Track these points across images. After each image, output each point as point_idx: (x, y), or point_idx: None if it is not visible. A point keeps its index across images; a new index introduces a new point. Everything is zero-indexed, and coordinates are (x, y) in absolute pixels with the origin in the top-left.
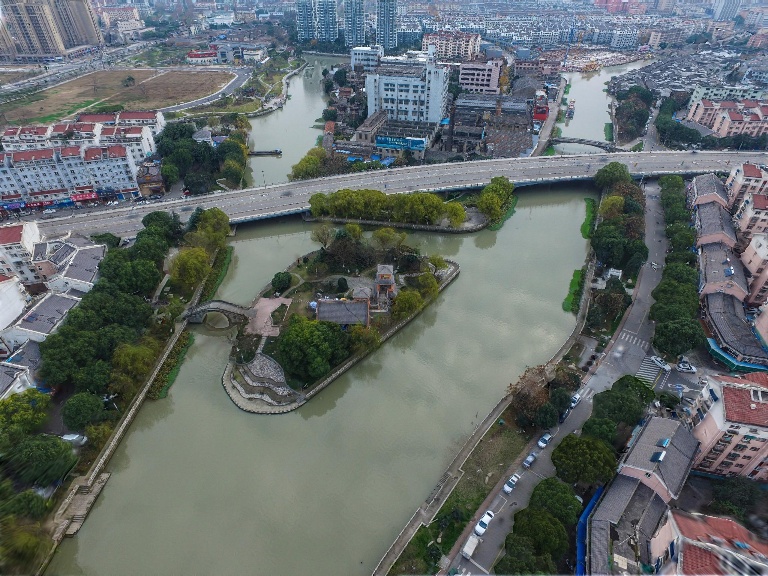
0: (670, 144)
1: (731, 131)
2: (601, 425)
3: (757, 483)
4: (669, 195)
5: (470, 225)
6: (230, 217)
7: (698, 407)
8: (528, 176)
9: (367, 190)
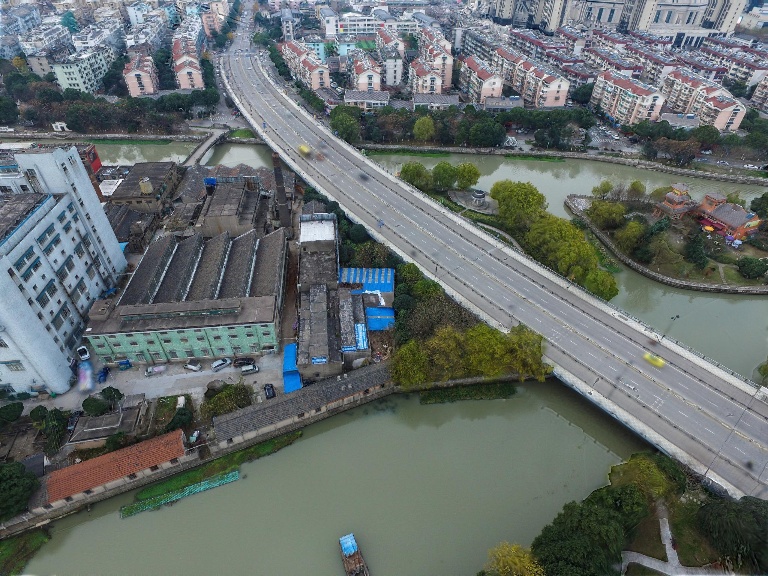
0: (202, 114)
1: (203, 82)
2: (683, 130)
3: (659, 113)
4: (386, 110)
5: (490, 198)
6: (740, 393)
7: (646, 111)
8: (361, 166)
9: (559, 226)
